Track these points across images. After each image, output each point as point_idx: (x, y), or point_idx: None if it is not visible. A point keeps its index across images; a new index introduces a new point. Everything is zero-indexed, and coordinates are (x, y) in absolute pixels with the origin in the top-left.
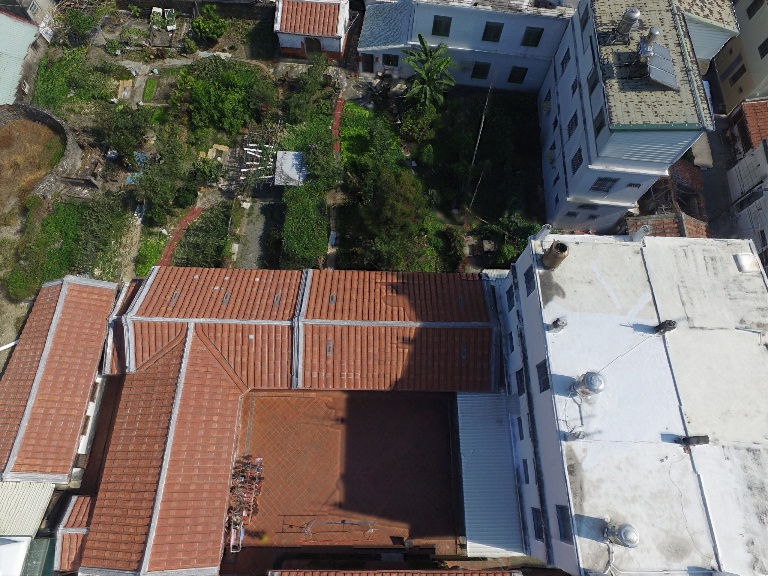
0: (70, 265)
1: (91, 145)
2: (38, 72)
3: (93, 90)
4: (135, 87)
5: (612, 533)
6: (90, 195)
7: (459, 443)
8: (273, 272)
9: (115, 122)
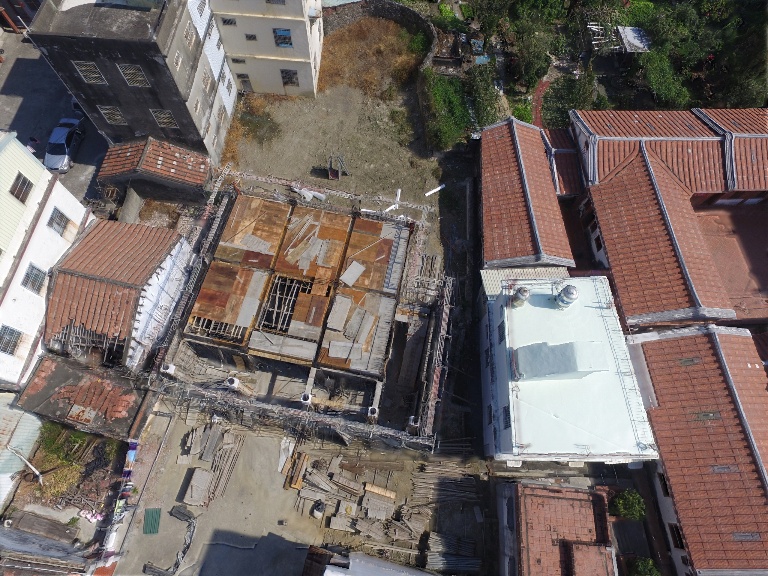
0: (465, 126)
1: (444, 32)
2: None
3: None
4: None
5: None
6: (456, 72)
7: None
8: (667, 112)
9: (487, 4)
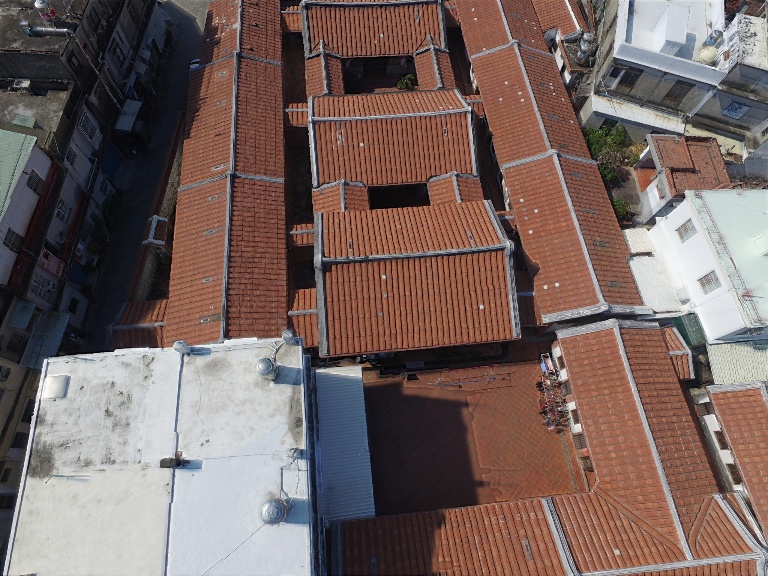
0: None
1: None
2: None
3: None
4: None
5: (275, 370)
6: None
7: None
8: None
9: None
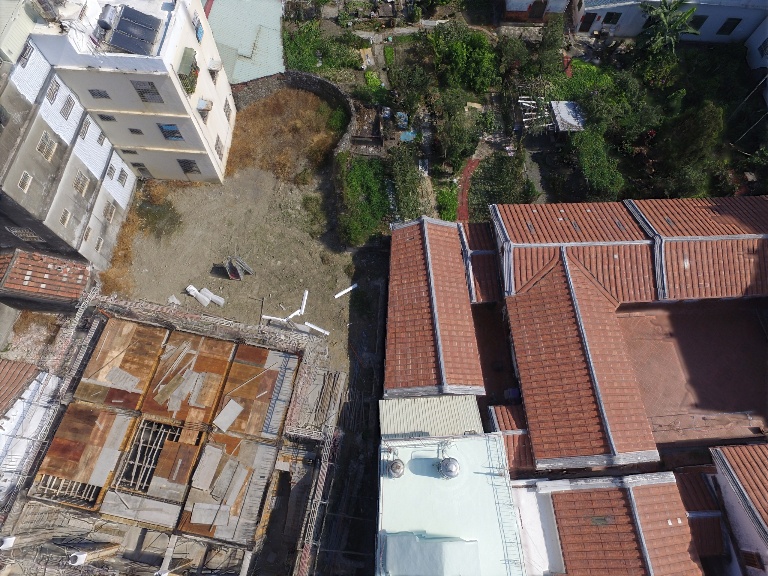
0: (382, 215)
1: (365, 107)
2: (284, 44)
3: (339, 59)
4: (376, 55)
5: None
6: (377, 152)
7: None
8: (597, 204)
9: (407, 80)
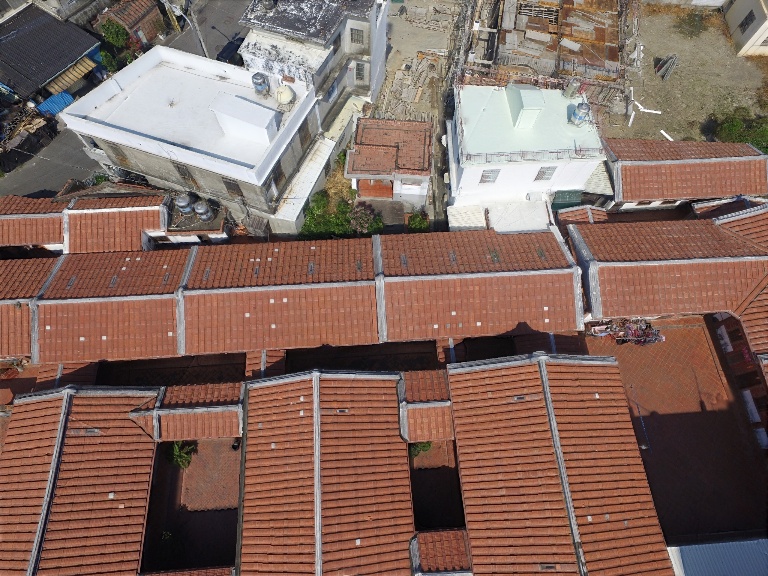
0: None
1: None
2: None
3: None
4: None
5: None
6: None
7: (767, 538)
8: None
9: None
